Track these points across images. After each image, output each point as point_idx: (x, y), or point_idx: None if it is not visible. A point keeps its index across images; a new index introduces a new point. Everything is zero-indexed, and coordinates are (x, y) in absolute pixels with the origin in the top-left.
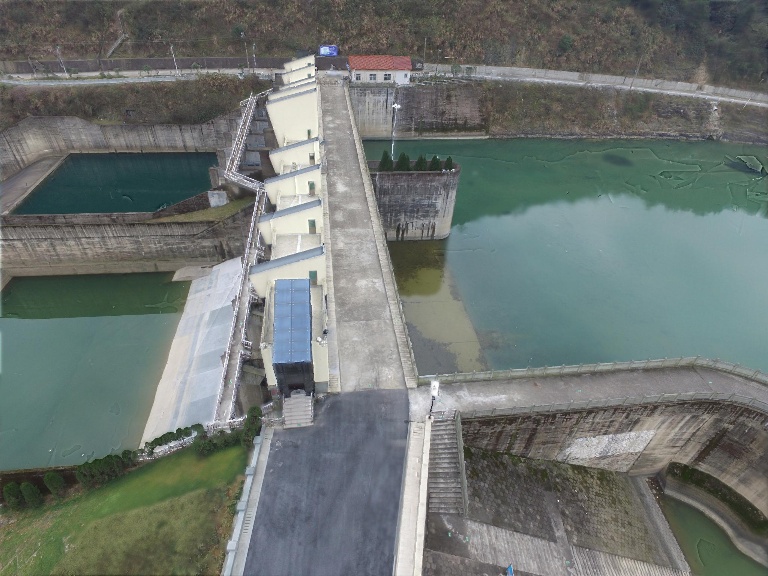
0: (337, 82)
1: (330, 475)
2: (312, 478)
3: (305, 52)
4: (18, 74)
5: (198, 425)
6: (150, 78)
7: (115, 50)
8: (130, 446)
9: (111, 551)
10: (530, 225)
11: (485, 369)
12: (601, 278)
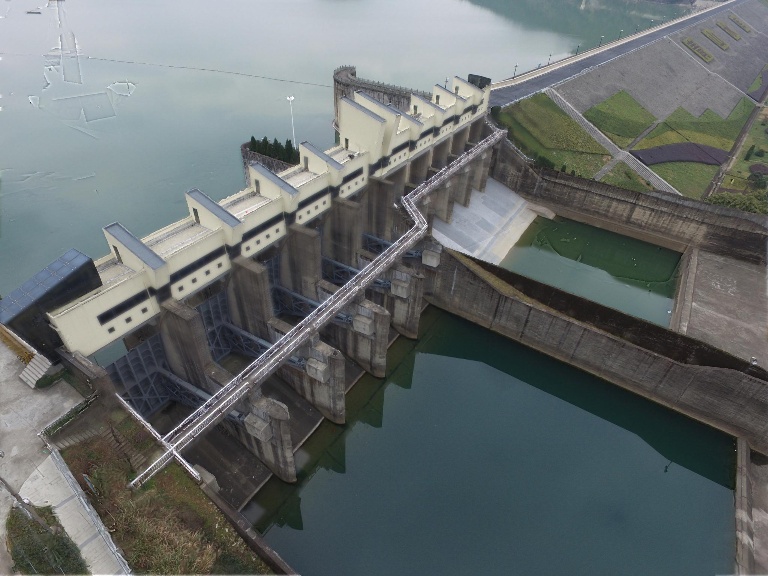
0: None
1: None
2: None
3: None
4: None
5: (510, 133)
6: None
7: None
8: (535, 226)
9: (540, 133)
10: None
11: None
12: (231, 159)
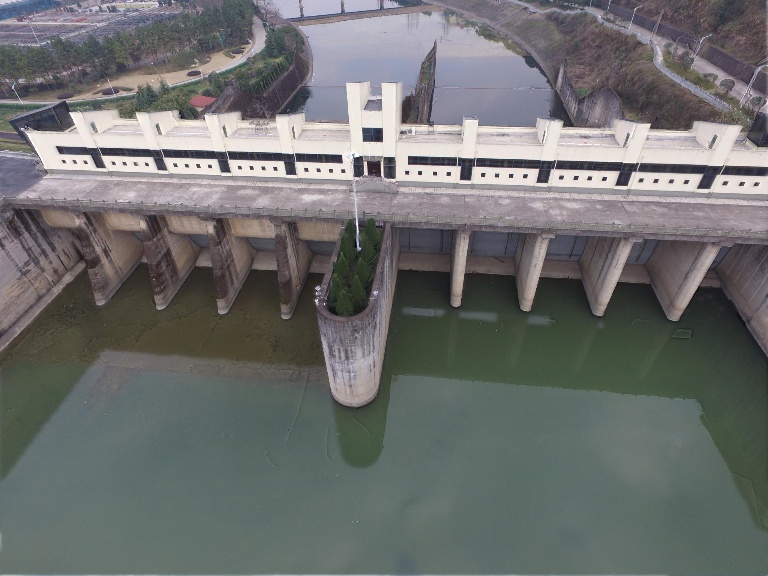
0: None
1: (2, 173)
2: (8, 169)
3: (767, 123)
4: (699, 57)
5: None
6: (706, 94)
7: None
8: None
9: None
10: None
11: (83, 359)
12: None
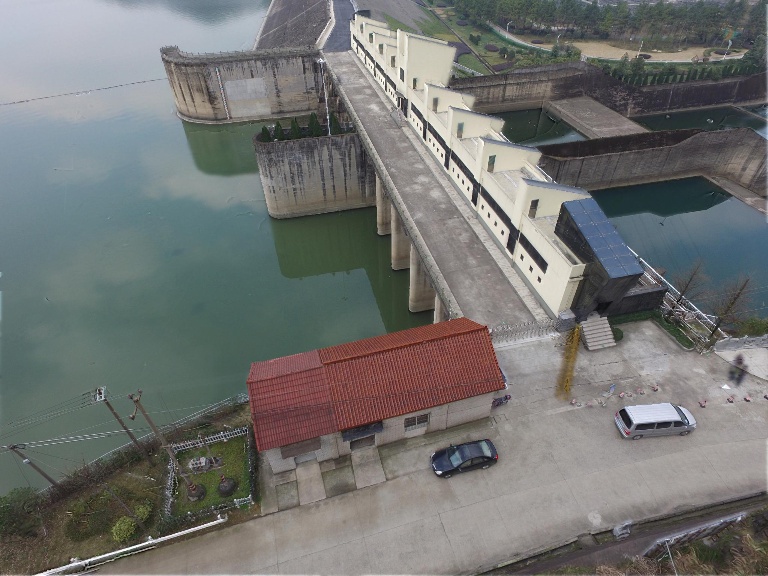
0: (498, 334)
1: None
2: None
3: None
4: None
5: None
6: None
7: None
8: None
9: None
10: (162, 239)
11: None
12: (142, 193)
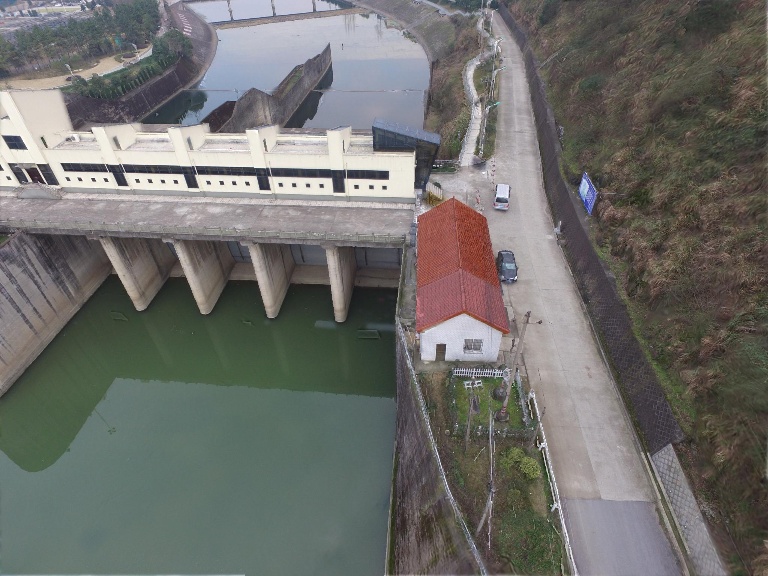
0: None
1: None
2: None
3: None
4: None
5: None
6: None
7: (549, 62)
8: None
9: None
10: None
11: None
12: None
